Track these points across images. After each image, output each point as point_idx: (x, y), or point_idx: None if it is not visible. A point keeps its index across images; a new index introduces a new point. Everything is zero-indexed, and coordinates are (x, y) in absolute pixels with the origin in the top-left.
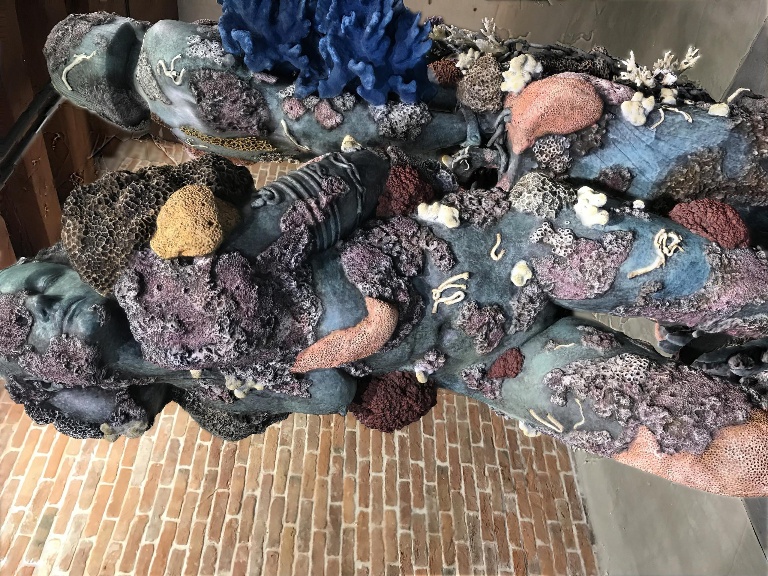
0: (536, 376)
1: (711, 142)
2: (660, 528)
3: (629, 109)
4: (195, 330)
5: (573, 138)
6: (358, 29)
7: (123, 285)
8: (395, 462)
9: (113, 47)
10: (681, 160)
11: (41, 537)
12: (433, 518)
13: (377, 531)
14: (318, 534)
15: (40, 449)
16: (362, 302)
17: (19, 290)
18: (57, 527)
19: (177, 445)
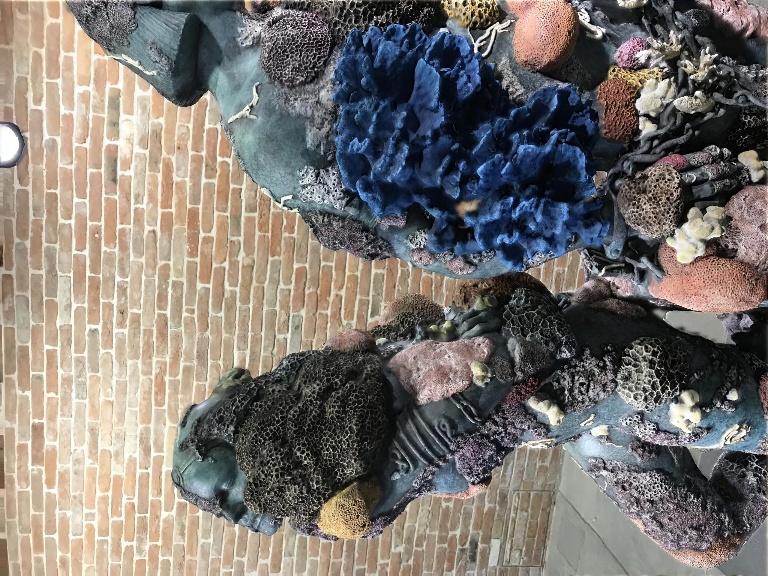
0: (584, 452)
1: None
2: None
3: None
4: None
5: None
6: None
7: None
8: None
9: (178, 67)
10: None
11: (113, 117)
12: None
13: None
14: None
15: None
16: (466, 484)
17: (212, 498)
18: (125, 108)
19: None
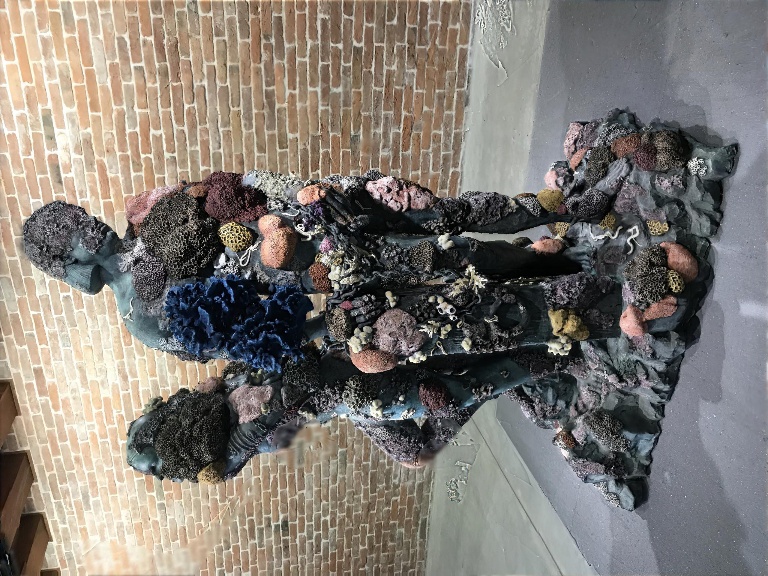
0: None
1: None
2: (499, 151)
3: None
4: None
5: None
6: None
7: None
8: (317, 46)
9: None
10: None
11: (50, 133)
12: (347, 96)
13: (303, 110)
14: (258, 115)
15: (6, 58)
16: None
17: (147, 471)
18: (57, 124)
19: (124, 43)
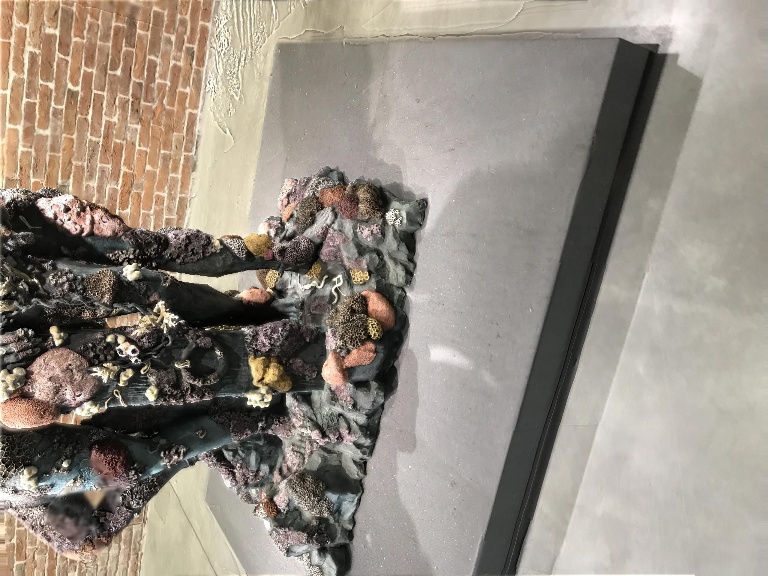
0: None
1: None
2: (223, 217)
3: None
4: None
5: None
6: None
7: None
8: (22, 80)
9: None
10: None
11: None
12: (55, 140)
13: None
14: None
15: None
16: None
17: None
18: None
19: None
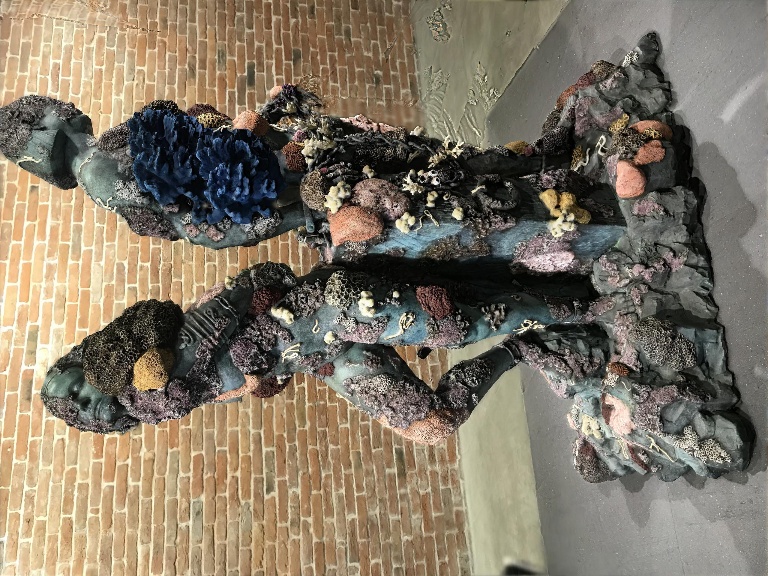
0: (340, 379)
1: (451, 233)
2: None
3: (399, 226)
4: (161, 413)
5: (367, 240)
6: (228, 193)
7: (123, 402)
8: (299, 269)
9: (54, 155)
10: (434, 241)
11: (32, 348)
12: None
13: None
14: None
15: (10, 280)
16: (242, 376)
17: (66, 396)
18: (42, 339)
19: (122, 268)
